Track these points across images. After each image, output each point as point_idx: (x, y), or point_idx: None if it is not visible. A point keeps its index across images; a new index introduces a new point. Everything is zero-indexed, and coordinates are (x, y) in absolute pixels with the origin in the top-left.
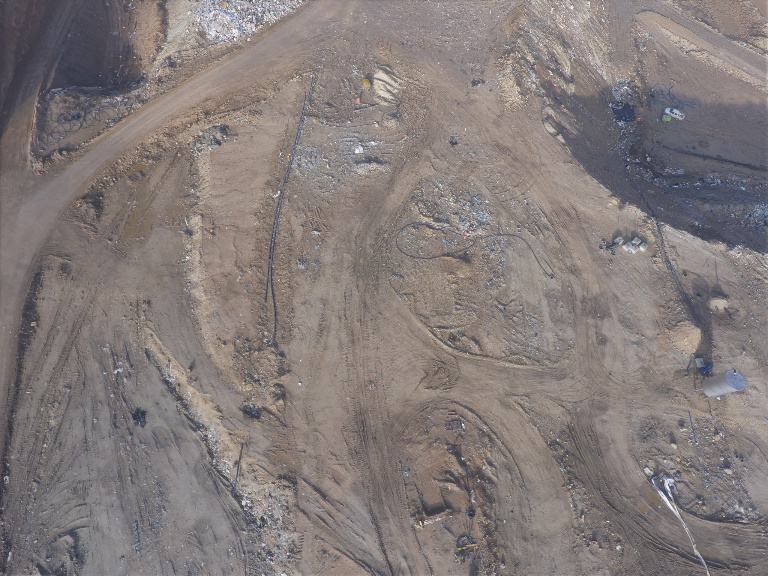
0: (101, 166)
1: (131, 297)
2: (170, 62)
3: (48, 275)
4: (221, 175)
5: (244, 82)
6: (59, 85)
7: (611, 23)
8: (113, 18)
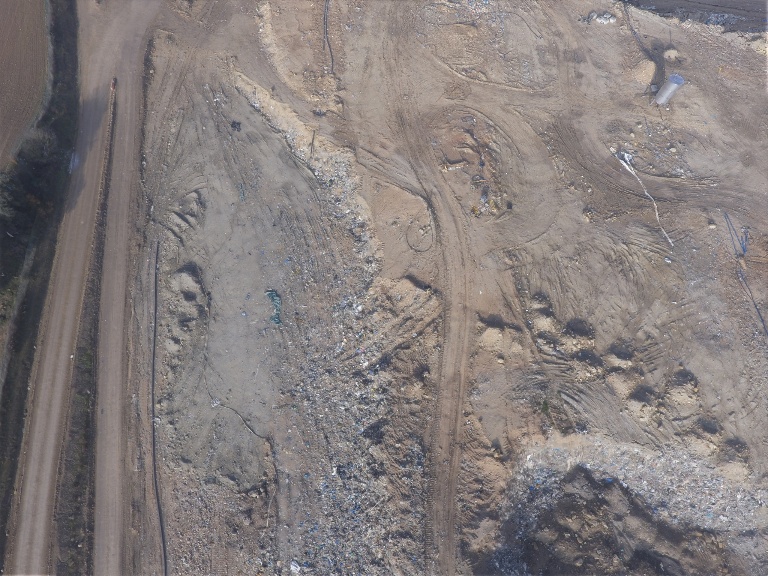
0: None
1: (221, 55)
2: None
3: (158, 42)
4: None
5: None
6: None
7: None
8: None
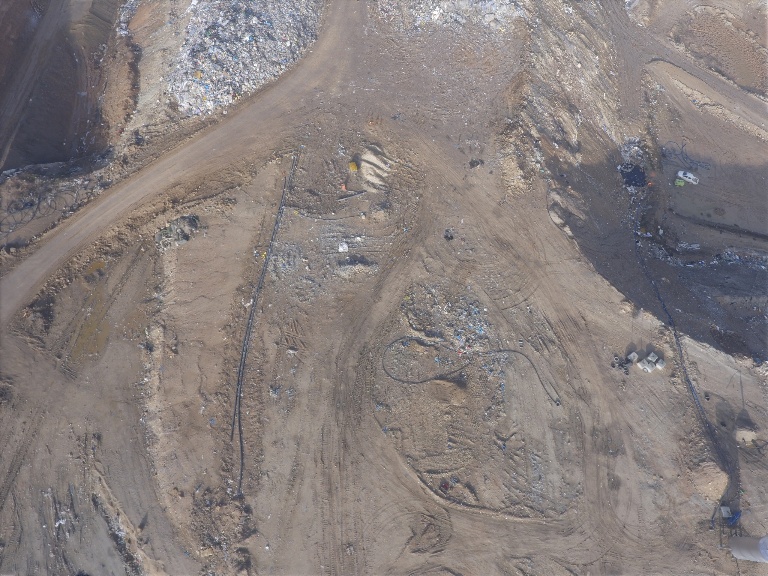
0: (53, 266)
1: (79, 429)
2: (137, 138)
3: None
4: (188, 277)
5: (218, 164)
6: (13, 164)
7: (620, 74)
8: (82, 76)
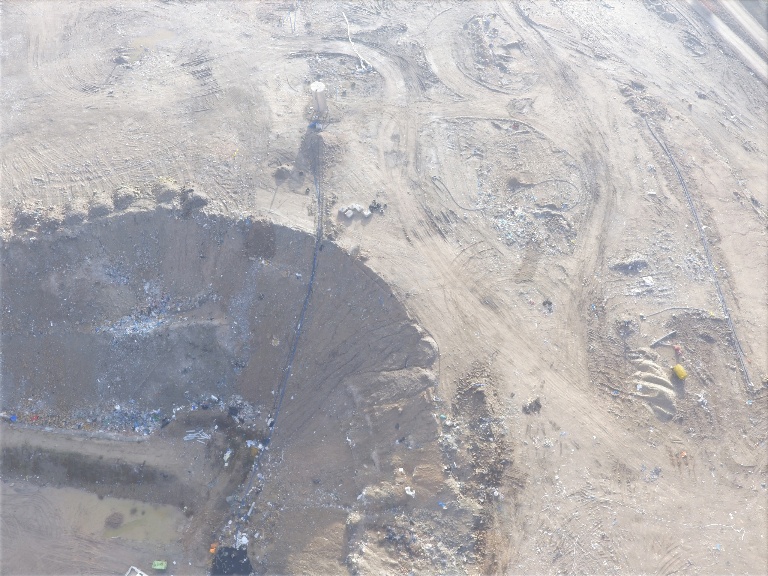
0: None
1: (762, 155)
2: None
3: None
4: (767, 250)
5: None
6: None
7: None
8: None
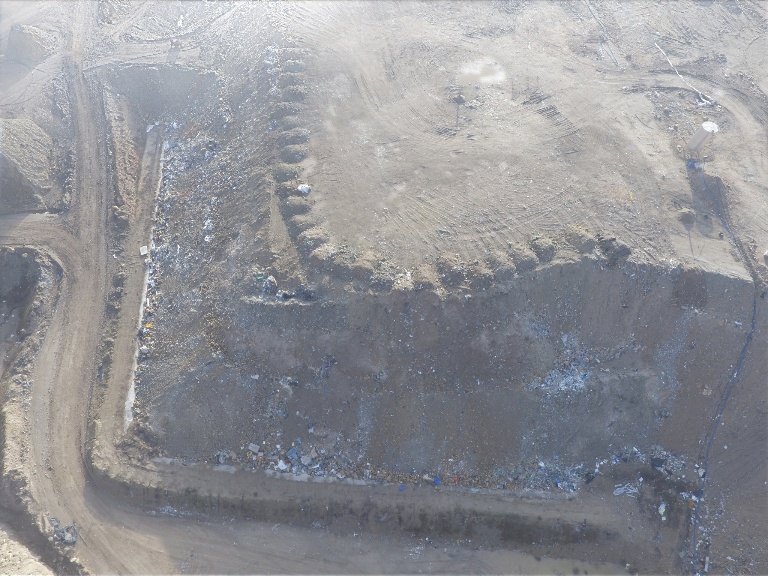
0: None
1: None
2: None
3: None
4: None
5: None
6: None
7: None
8: None
